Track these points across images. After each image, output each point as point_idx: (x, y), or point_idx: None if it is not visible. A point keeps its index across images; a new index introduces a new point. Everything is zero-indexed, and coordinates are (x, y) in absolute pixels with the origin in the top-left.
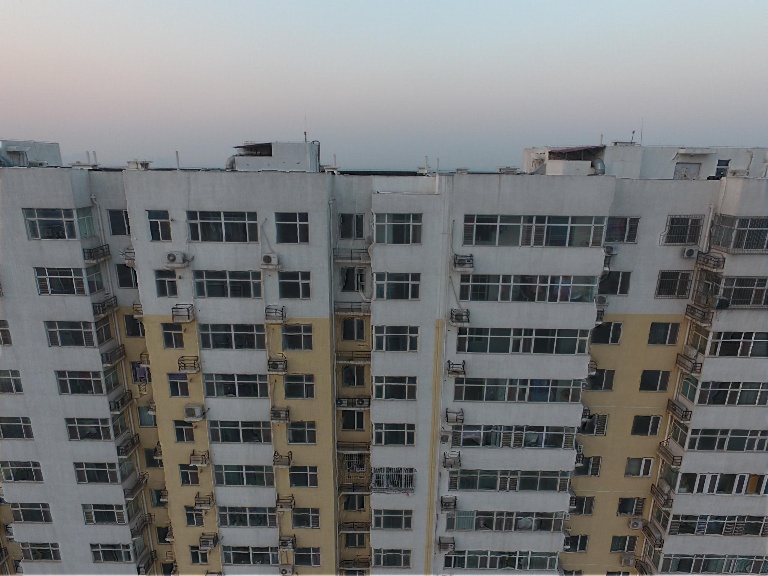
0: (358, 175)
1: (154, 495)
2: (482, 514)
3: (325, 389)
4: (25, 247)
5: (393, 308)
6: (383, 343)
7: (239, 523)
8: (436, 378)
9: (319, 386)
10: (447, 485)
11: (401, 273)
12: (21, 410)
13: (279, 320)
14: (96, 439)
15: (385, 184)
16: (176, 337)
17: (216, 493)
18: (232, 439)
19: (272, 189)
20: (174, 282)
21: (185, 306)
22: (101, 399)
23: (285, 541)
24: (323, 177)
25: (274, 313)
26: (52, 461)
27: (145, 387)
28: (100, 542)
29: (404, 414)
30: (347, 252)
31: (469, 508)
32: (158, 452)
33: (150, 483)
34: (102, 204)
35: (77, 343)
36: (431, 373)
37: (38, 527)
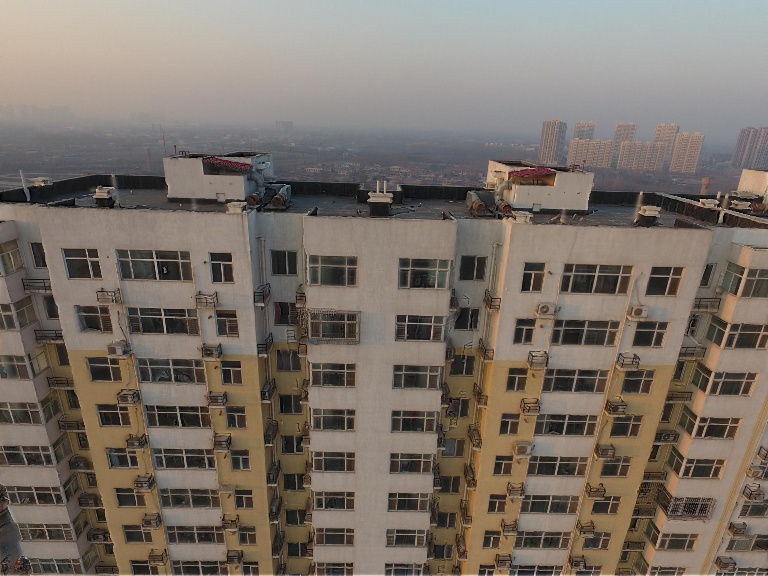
0: (720, 227)
1: (436, 516)
2: (762, 537)
3: (651, 429)
4: (393, 296)
5: (740, 357)
6: (718, 388)
7: (531, 545)
8: (760, 420)
9: (647, 426)
10: (739, 513)
11: (758, 325)
12: (350, 446)
13: (634, 368)
14: (415, 472)
15: (745, 236)
16: (519, 381)
17: (520, 520)
18: (545, 472)
19: (656, 244)
20: (531, 330)
21: (538, 353)
22: (431, 436)
23: (578, 562)
24: (710, 234)
25: (631, 362)
26: (369, 492)
27: (457, 421)
28: (396, 562)
29: (719, 451)
30: (696, 301)
31: (753, 532)
32: (471, 483)
33: (441, 507)
34: (458, 250)
35: (417, 384)
36: (757, 415)
37: (339, 549)
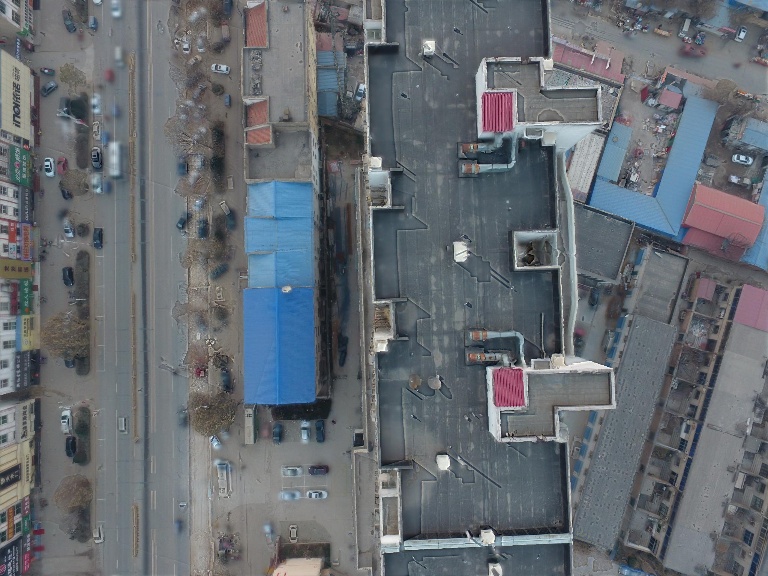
0: (399, 488)
1: None
2: None
3: None
4: None
5: None
6: None
7: None
8: None
9: None
10: None
11: None
12: None
13: None
14: None
15: None
16: None
17: None
18: None
19: None
20: None
21: None
22: None
23: None
24: None
25: None
26: None
27: None
28: None
29: None
30: None
31: None
32: None
33: None
34: None
35: None
36: None
37: None
